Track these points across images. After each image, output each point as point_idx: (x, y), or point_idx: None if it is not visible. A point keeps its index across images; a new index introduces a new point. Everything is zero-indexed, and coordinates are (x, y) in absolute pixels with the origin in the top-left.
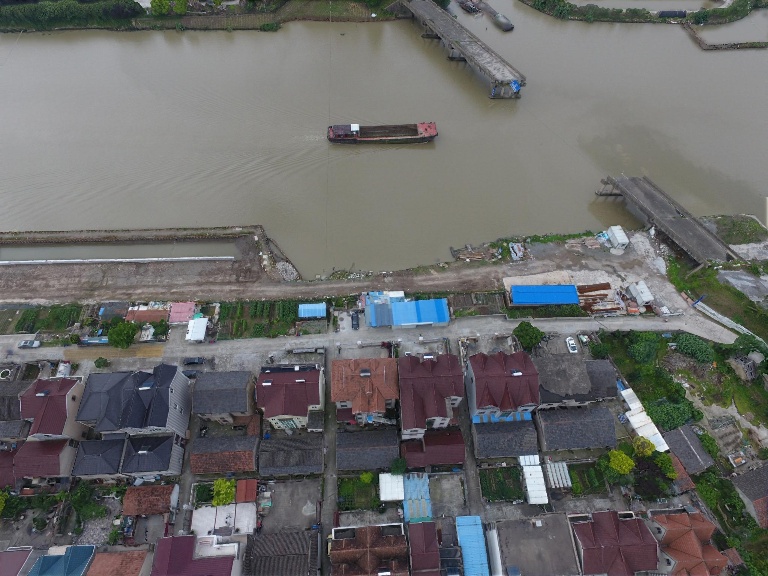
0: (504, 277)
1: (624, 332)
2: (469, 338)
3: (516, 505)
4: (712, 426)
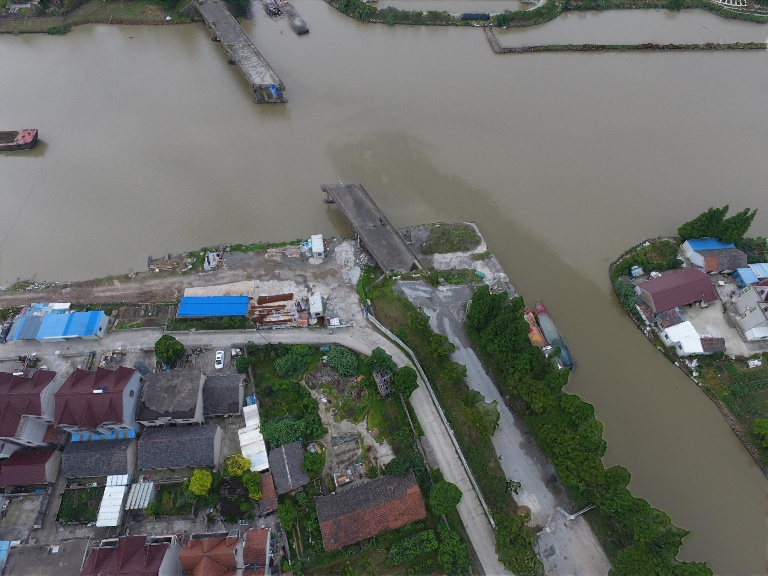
0: (187, 288)
1: (276, 345)
2: (115, 352)
3: (91, 527)
4: (333, 443)
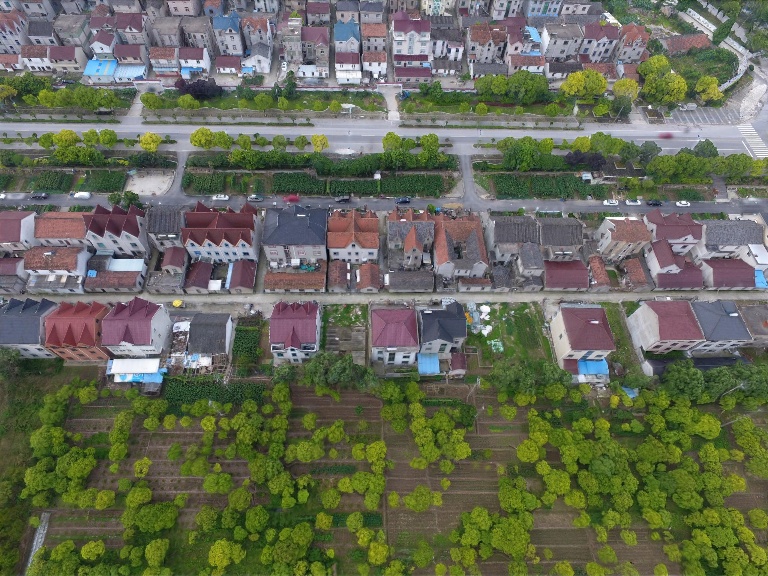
0: None
1: None
2: None
3: None
4: None
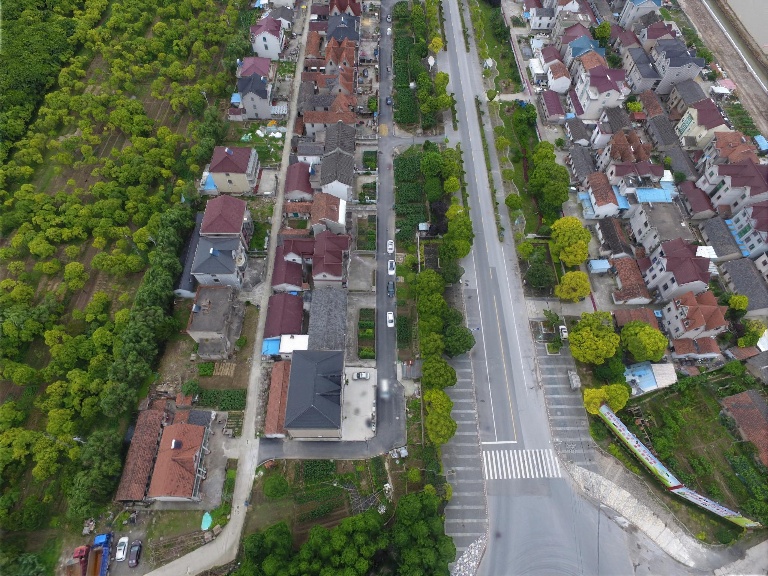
0: None
1: None
2: None
3: None
4: None
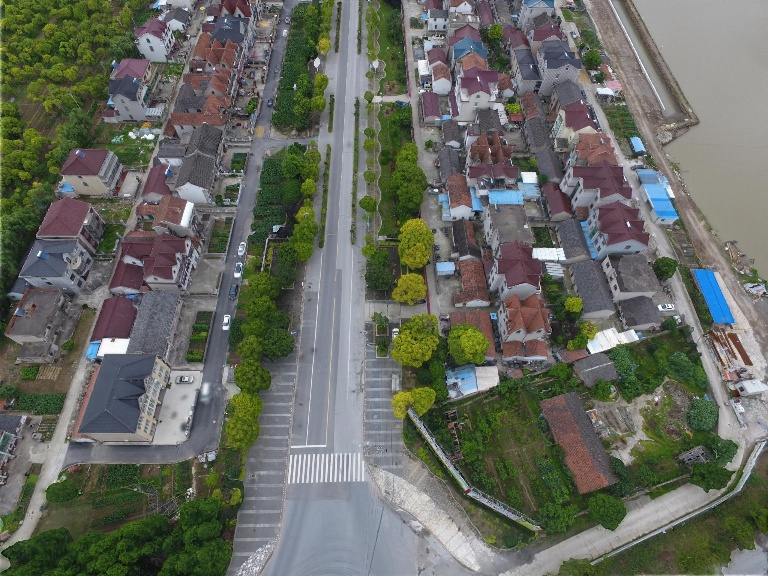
0: (720, 273)
1: None
2: None
3: None
4: (620, 408)
